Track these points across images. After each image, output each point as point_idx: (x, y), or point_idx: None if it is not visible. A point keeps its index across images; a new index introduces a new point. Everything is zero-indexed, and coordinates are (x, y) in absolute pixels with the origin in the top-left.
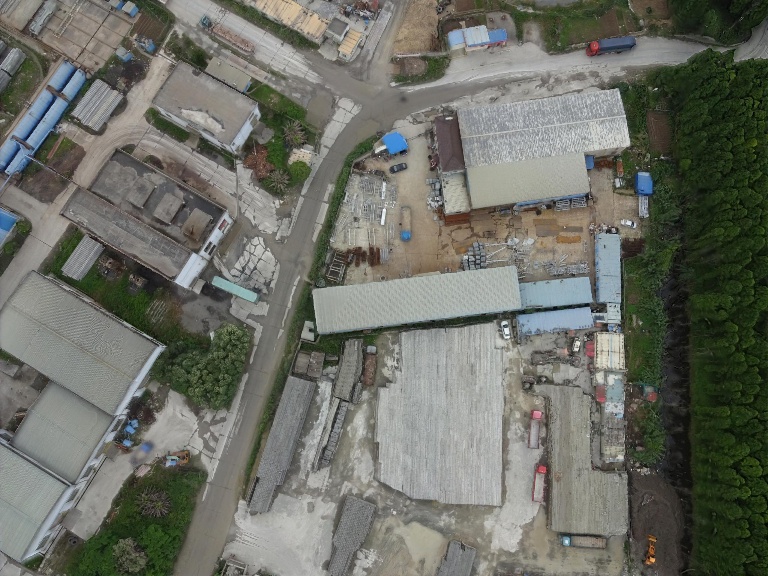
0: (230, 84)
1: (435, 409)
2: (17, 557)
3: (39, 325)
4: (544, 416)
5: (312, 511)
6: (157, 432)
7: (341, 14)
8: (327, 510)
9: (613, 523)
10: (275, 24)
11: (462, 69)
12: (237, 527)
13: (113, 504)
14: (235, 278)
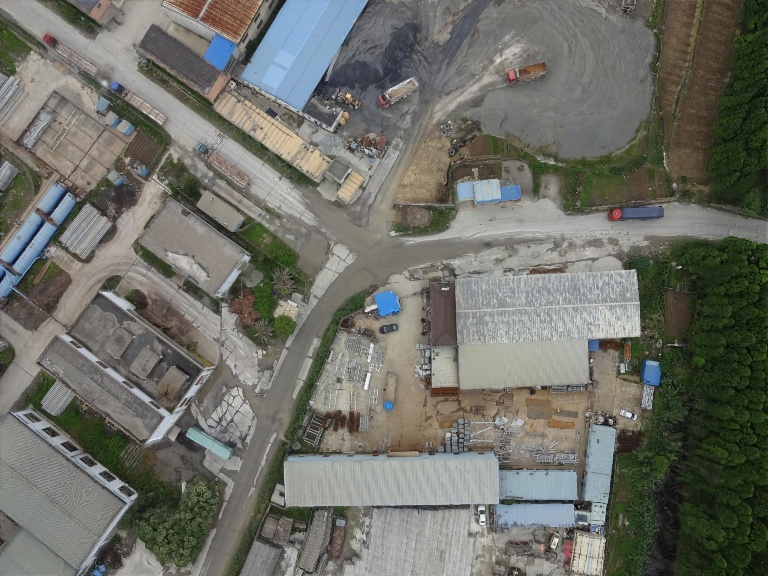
0: (221, 222)
1: None
2: None
3: (11, 472)
4: None
5: None
6: None
7: (345, 149)
8: None
9: None
10: (274, 156)
11: (469, 223)
12: None
13: None
14: (211, 429)
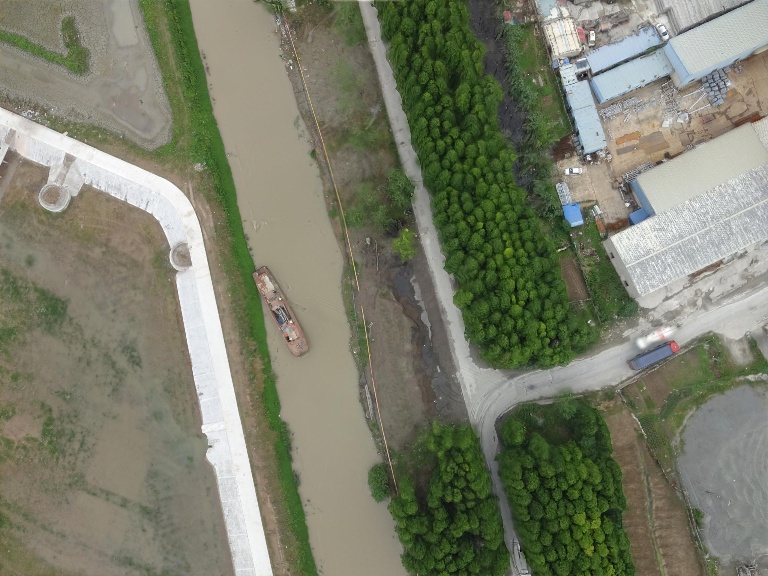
0: None
1: None
2: None
3: None
4: None
5: None
6: None
7: None
8: None
9: None
10: None
11: None
12: None
13: None
14: None
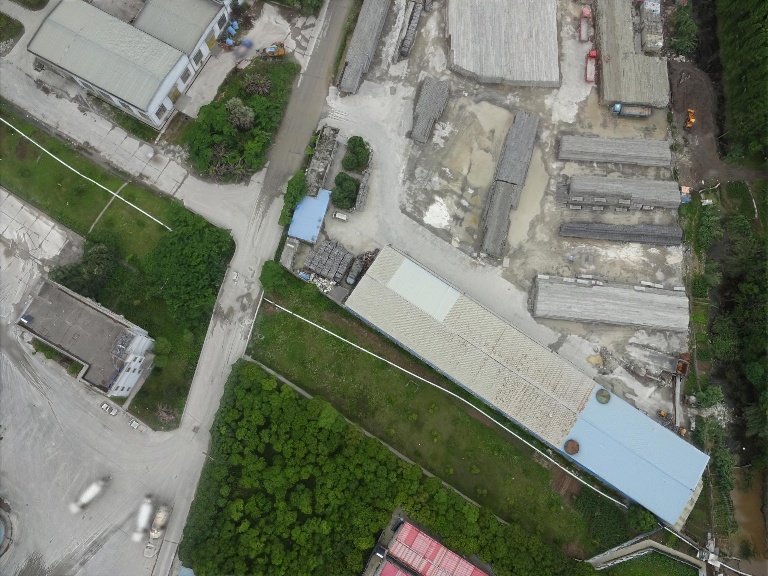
0: None
1: (498, 9)
2: (143, 106)
3: None
4: (591, 20)
5: (394, 93)
6: (255, 35)
7: None
8: (407, 93)
9: (657, 93)
10: None
11: None
12: (329, 106)
13: (219, 91)
14: None
